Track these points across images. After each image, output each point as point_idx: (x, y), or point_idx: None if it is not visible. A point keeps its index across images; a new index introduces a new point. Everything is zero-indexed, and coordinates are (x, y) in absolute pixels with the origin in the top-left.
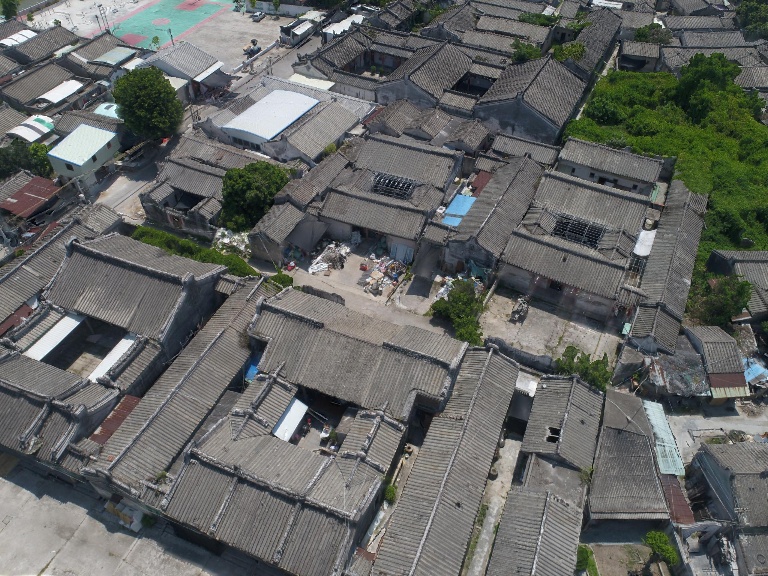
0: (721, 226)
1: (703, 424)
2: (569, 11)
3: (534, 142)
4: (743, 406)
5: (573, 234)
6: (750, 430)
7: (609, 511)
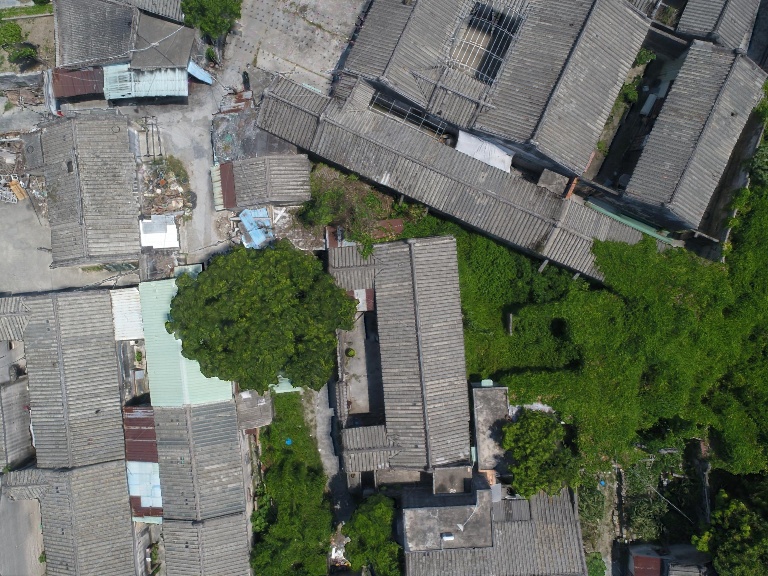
0: (544, 294)
1: (202, 166)
2: None
3: None
4: (228, 219)
5: (466, 24)
6: (198, 216)
7: (57, 8)
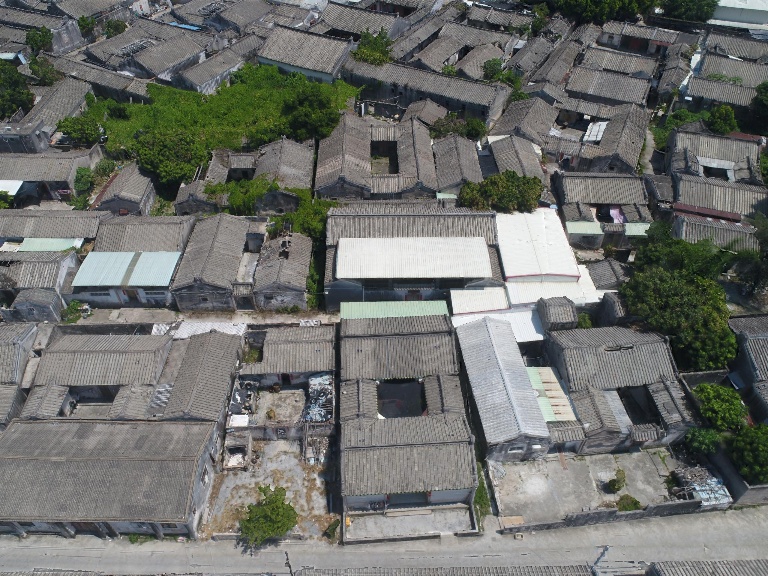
0: None
1: None
2: (528, 89)
3: (236, 42)
4: None
5: None
6: None
7: None
